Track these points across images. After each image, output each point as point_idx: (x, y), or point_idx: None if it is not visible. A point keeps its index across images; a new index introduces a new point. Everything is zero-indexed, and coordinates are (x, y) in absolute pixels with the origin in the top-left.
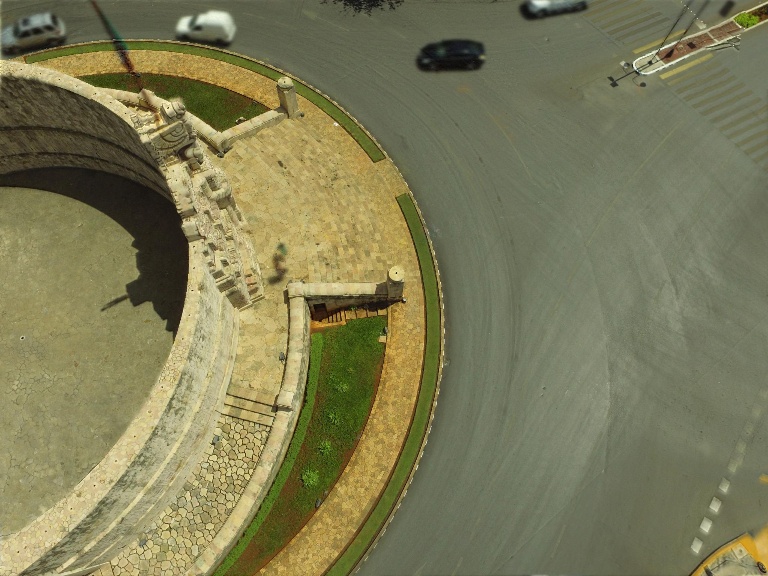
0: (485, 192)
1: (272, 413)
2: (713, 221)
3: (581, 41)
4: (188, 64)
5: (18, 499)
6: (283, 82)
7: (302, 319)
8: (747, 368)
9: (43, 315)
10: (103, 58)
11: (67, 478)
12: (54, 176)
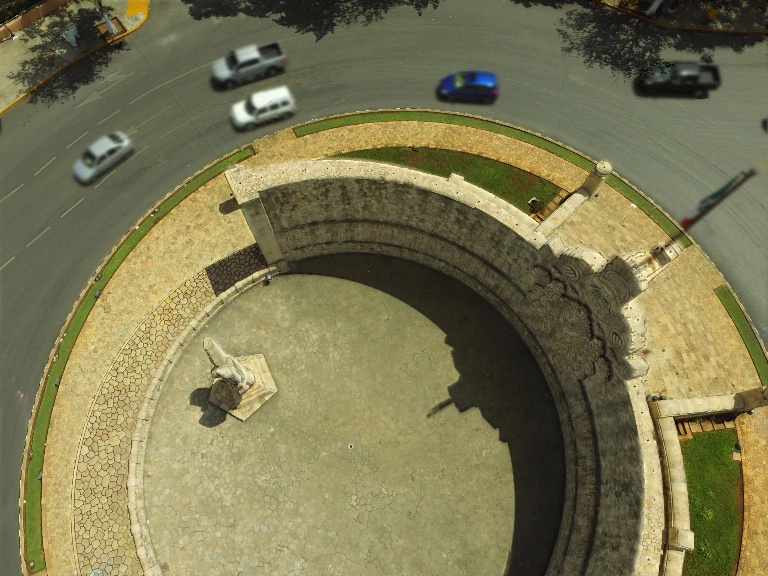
0: None
1: None
2: None
3: None
4: (464, 137)
5: None
6: (603, 167)
7: (678, 443)
8: None
9: (367, 420)
10: (375, 130)
11: None
12: (349, 262)
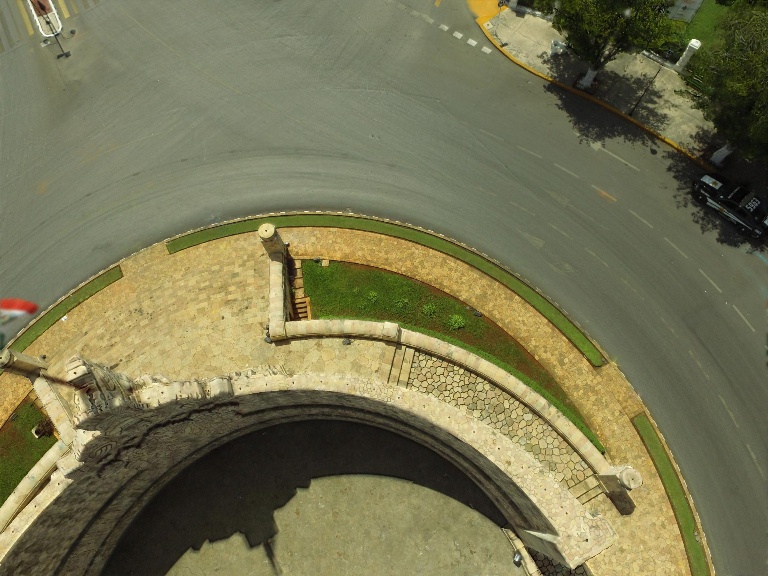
0: (175, 172)
1: (402, 349)
2: (227, 2)
3: (6, 76)
4: None
5: None
6: (0, 360)
7: (309, 322)
8: (356, 0)
9: None
10: None
11: (471, 572)
12: None
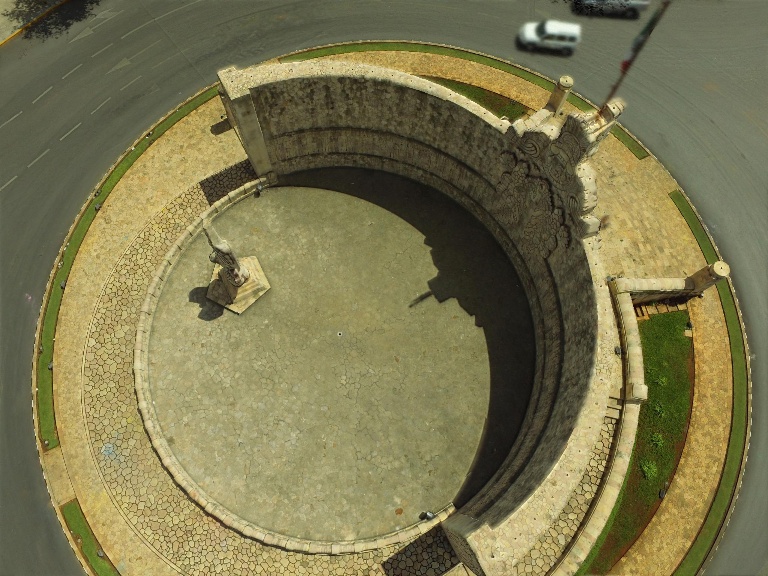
0: (754, 188)
1: (618, 406)
2: None
3: None
4: (439, 64)
5: (372, 490)
6: (565, 81)
7: (634, 314)
8: None
9: (354, 312)
10: (356, 59)
11: (414, 470)
12: (334, 176)
